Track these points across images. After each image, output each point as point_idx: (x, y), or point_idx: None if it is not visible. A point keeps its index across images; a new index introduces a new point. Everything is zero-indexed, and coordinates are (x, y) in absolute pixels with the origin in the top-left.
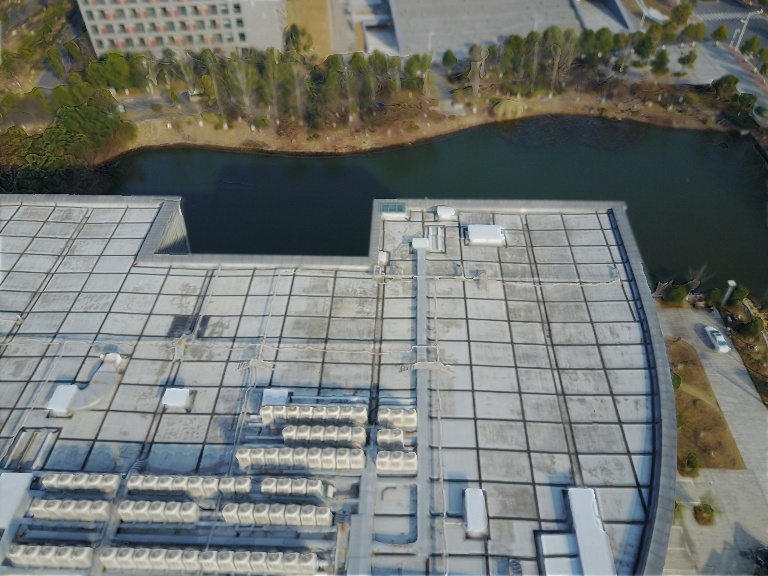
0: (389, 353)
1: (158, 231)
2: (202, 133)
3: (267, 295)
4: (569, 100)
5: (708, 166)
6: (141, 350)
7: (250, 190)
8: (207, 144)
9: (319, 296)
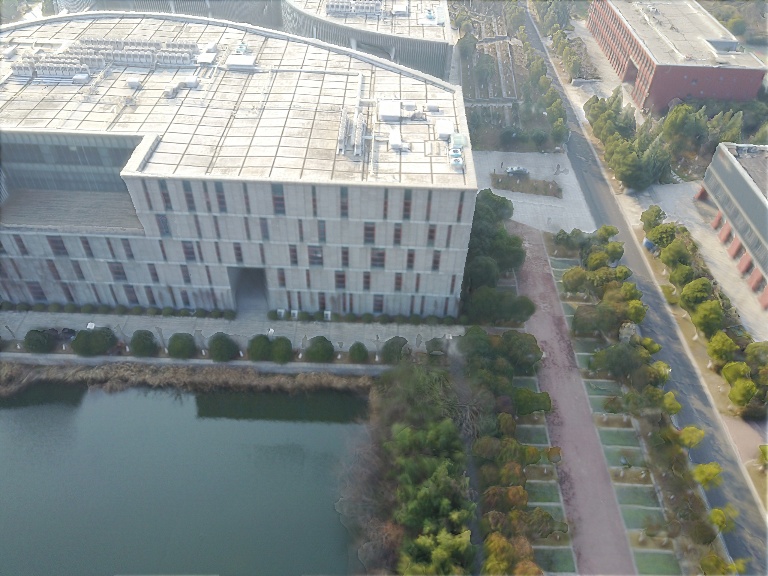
0: (8, 96)
1: (141, 148)
2: None
3: (69, 119)
4: None
5: None
6: None
7: None
8: None
9: (34, 118)
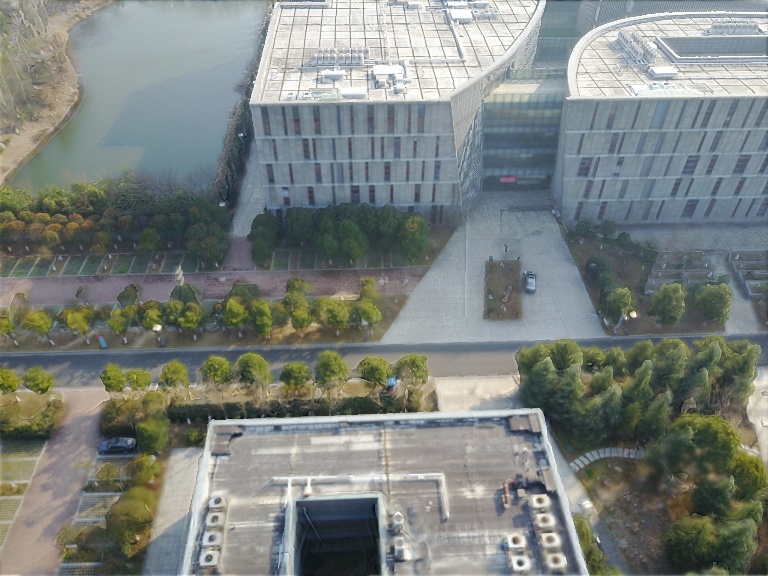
0: None
1: (307, 3)
2: (1, 161)
3: None
4: (56, 22)
5: (142, 12)
6: (384, 1)
7: (112, 135)
8: (19, 161)
9: None
